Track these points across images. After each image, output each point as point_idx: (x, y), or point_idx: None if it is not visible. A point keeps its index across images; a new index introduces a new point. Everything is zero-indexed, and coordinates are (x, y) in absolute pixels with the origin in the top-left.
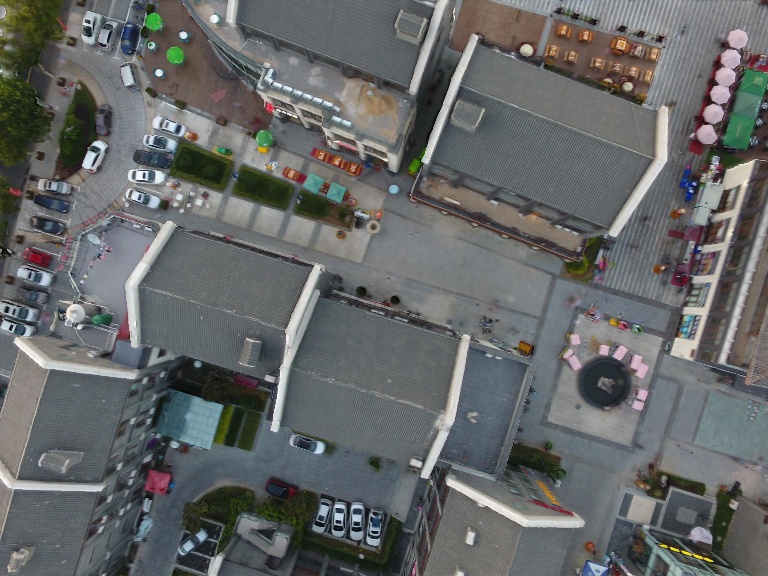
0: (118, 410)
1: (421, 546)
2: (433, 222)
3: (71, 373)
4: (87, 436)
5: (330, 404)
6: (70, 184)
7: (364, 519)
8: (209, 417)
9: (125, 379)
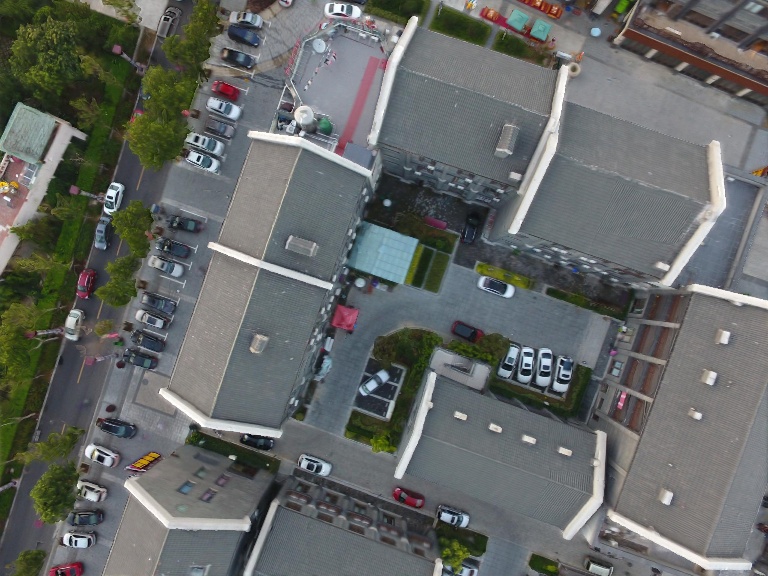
0: (351, 208)
1: (627, 380)
2: (632, 68)
3: (317, 158)
4: (323, 230)
5: (583, 198)
6: (262, 18)
7: (552, 365)
8: (403, 251)
9: (360, 177)
